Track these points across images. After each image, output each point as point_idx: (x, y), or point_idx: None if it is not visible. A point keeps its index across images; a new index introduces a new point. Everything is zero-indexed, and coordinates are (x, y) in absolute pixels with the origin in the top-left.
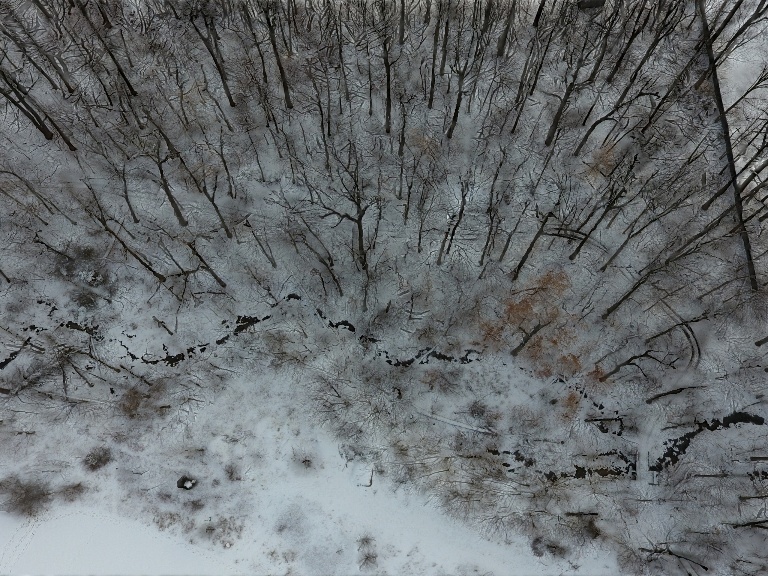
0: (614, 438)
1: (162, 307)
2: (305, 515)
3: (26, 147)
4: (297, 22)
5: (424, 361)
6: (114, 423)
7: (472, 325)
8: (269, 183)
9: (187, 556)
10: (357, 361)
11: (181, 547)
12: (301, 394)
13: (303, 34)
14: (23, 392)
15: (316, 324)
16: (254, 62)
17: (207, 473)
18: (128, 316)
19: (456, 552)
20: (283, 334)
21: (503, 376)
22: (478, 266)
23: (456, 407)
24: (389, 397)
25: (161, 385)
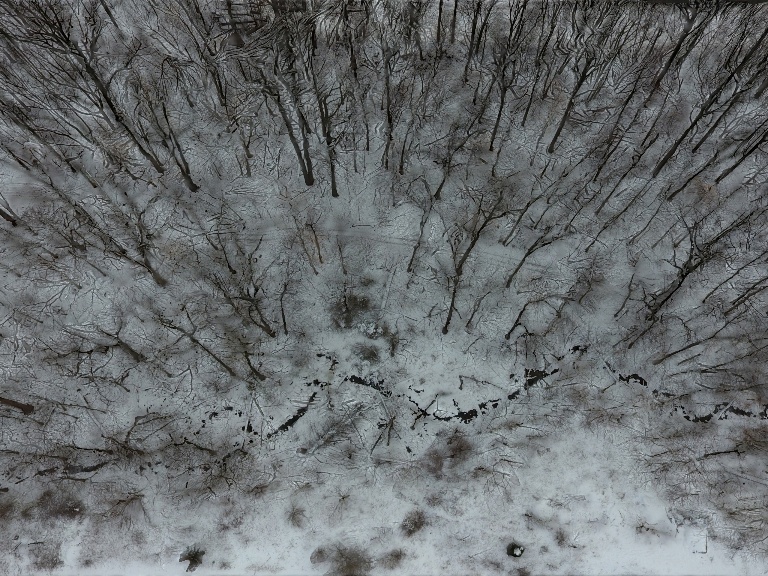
0: None
1: (447, 360)
2: None
3: (287, 193)
4: (550, 64)
5: (723, 417)
6: (420, 484)
7: (767, 379)
8: (540, 230)
9: None
10: (656, 417)
11: None
12: (616, 454)
13: (556, 76)
14: (319, 451)
15: (608, 378)
16: (509, 105)
17: (534, 539)
18: (413, 370)
19: None
20: (588, 390)
21: None
22: (766, 317)
23: (765, 466)
24: (696, 455)
25: (463, 444)
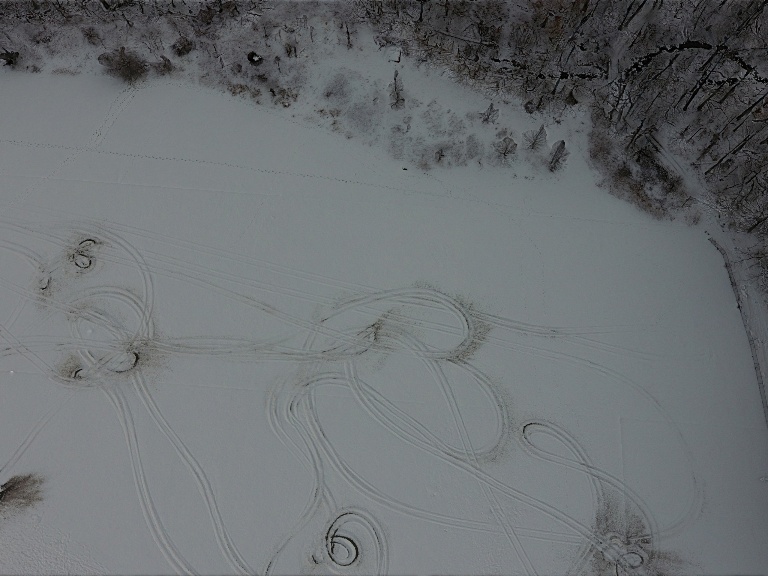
0: (592, 54)
1: None
2: (348, 81)
3: None
4: None
5: None
6: None
7: None
8: None
9: (255, 113)
10: None
11: (250, 107)
12: (343, 5)
13: None
14: (120, 8)
15: None
16: None
17: (270, 53)
18: None
19: (466, 106)
20: None
21: (504, 9)
22: None
23: None
24: (413, 19)
25: (231, 4)
